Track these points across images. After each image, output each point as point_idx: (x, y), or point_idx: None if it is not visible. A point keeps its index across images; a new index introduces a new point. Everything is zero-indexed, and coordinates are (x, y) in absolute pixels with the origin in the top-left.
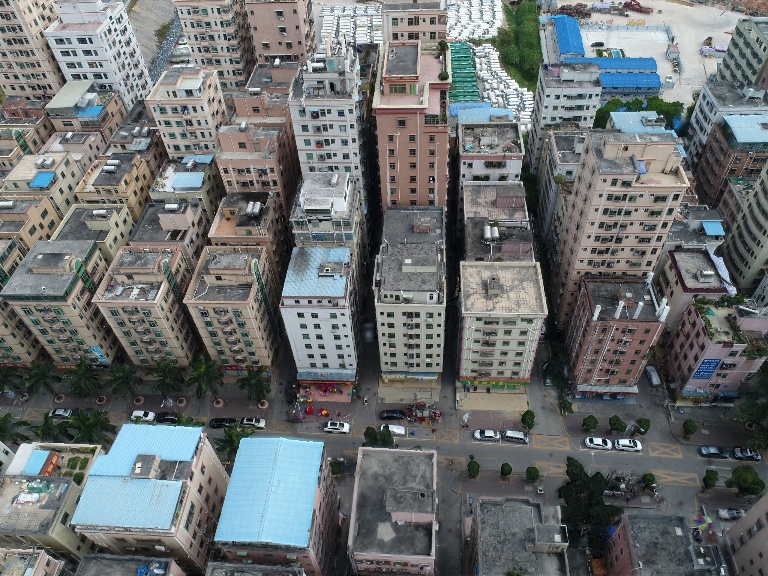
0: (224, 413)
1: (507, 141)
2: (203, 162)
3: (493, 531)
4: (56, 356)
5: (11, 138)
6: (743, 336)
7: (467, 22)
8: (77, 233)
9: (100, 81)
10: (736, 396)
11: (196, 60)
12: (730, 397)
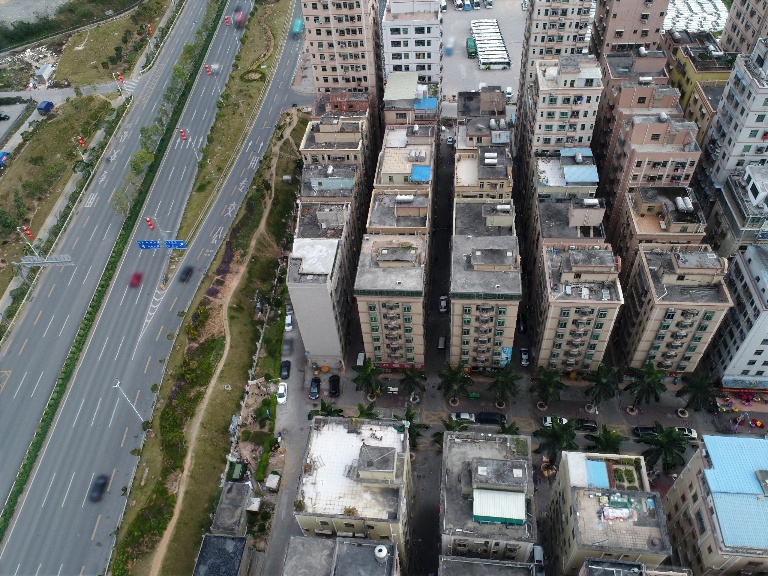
0: (643, 421)
1: None
2: (586, 155)
3: None
4: (456, 357)
5: (357, 131)
6: None
7: (690, 14)
8: (474, 229)
9: (421, 73)
10: None
11: (534, 50)
12: None
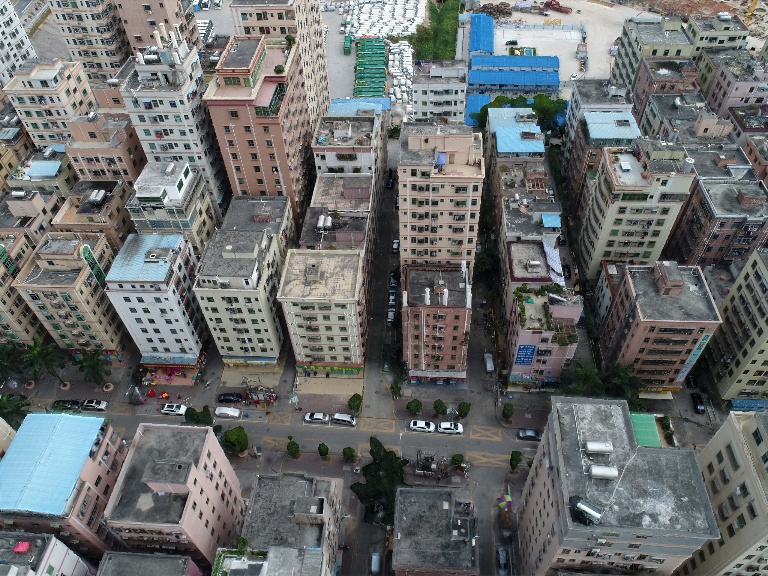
0: (69, 395)
1: (362, 134)
2: (63, 151)
3: (265, 504)
4: None
5: None
6: (555, 323)
7: (389, 19)
8: None
9: None
10: (560, 382)
11: (73, 52)
12: (554, 383)
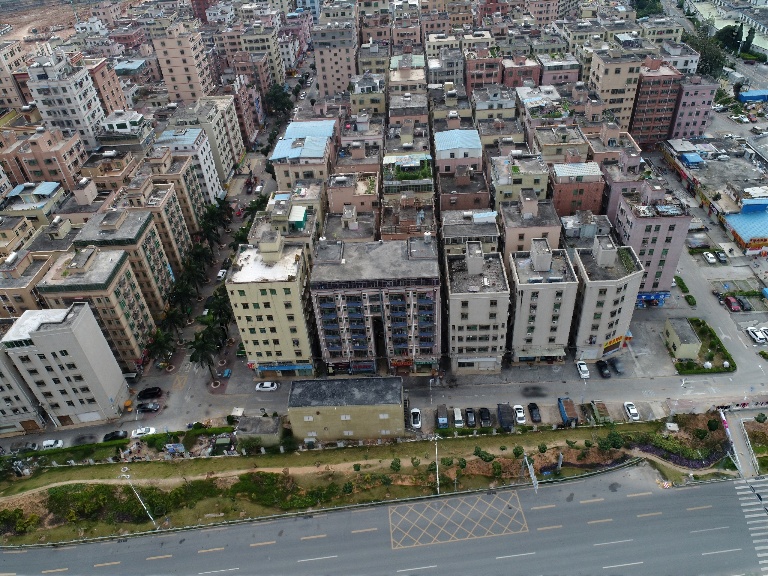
0: None
1: None
2: None
3: None
4: (160, 300)
5: None
6: None
7: None
8: (61, 245)
9: None
10: None
11: None
12: None
